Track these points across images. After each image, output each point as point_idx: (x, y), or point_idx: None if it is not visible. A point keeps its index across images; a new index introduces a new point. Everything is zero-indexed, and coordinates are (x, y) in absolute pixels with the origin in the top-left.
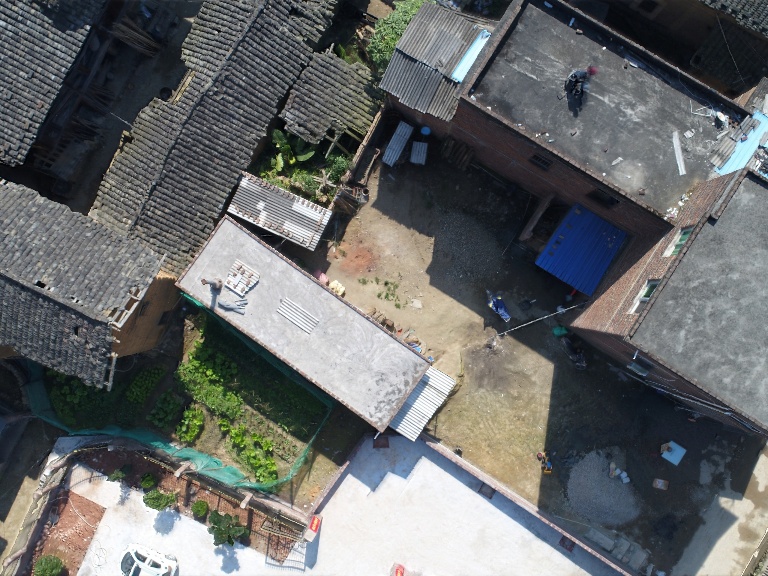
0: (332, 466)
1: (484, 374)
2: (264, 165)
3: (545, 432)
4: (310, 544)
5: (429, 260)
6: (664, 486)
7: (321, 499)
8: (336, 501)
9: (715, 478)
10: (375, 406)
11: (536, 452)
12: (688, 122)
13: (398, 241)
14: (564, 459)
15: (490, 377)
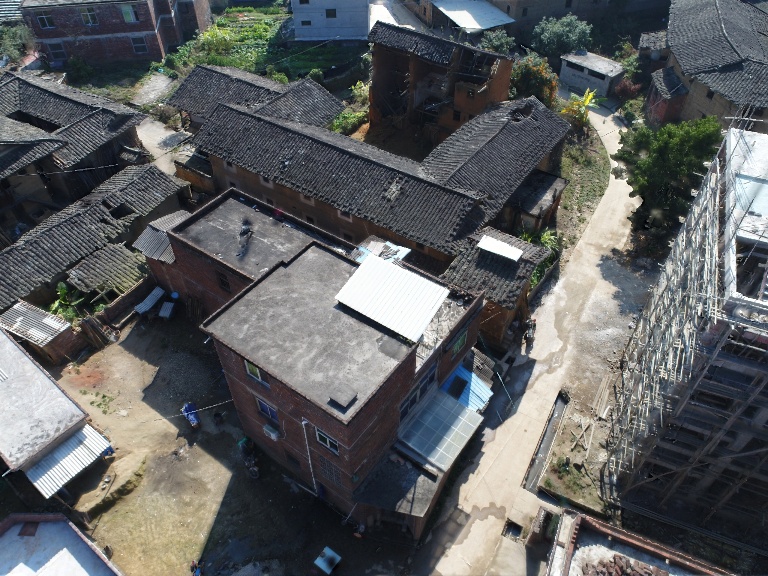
0: None
1: (163, 479)
2: (45, 308)
3: (206, 540)
4: None
5: (149, 383)
6: None
7: None
8: None
9: None
10: (19, 447)
11: (191, 562)
12: None
13: (129, 369)
14: (218, 570)
15: (168, 482)
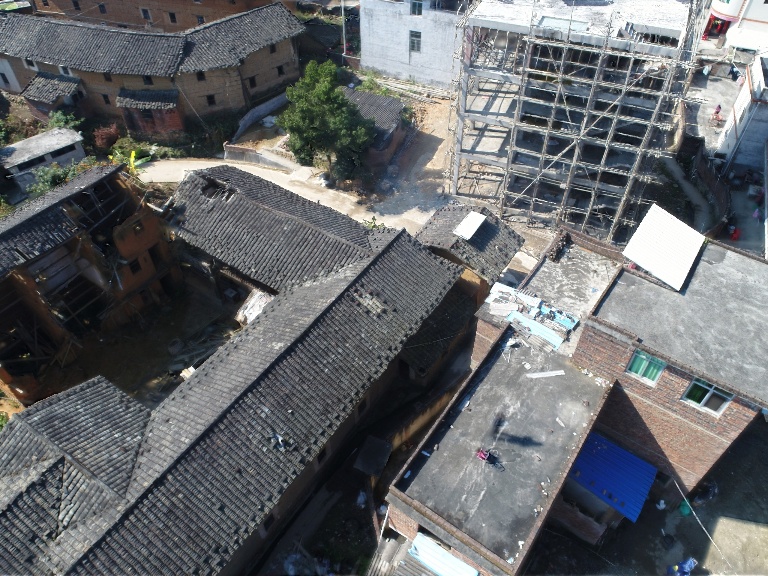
0: None
1: None
2: None
3: None
4: None
5: None
6: None
7: None
8: None
9: None
10: None
11: None
12: (517, 366)
13: None
14: None
15: None
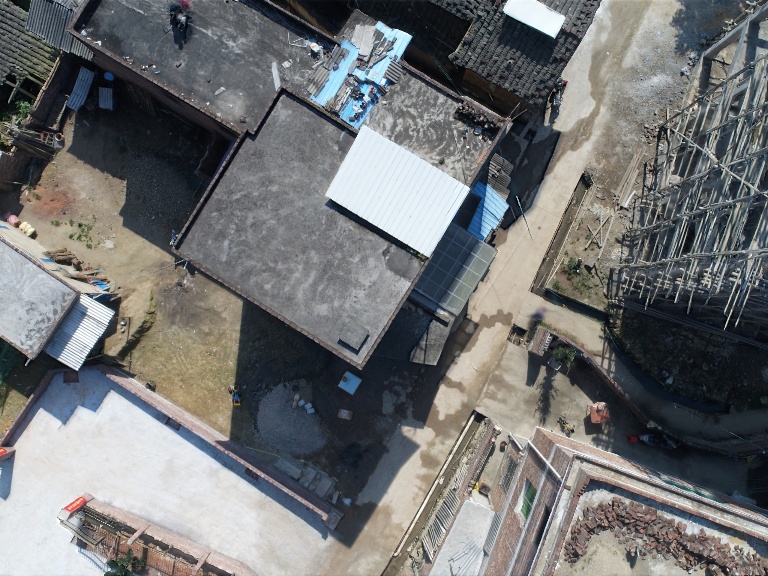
0: (24, 401)
1: (177, 311)
2: None
3: (235, 366)
4: (4, 476)
5: (122, 202)
6: (349, 416)
7: (7, 431)
8: (29, 434)
9: (397, 408)
10: (26, 334)
11: (227, 386)
12: (286, 53)
13: (93, 185)
14: (253, 392)
15: (182, 314)
